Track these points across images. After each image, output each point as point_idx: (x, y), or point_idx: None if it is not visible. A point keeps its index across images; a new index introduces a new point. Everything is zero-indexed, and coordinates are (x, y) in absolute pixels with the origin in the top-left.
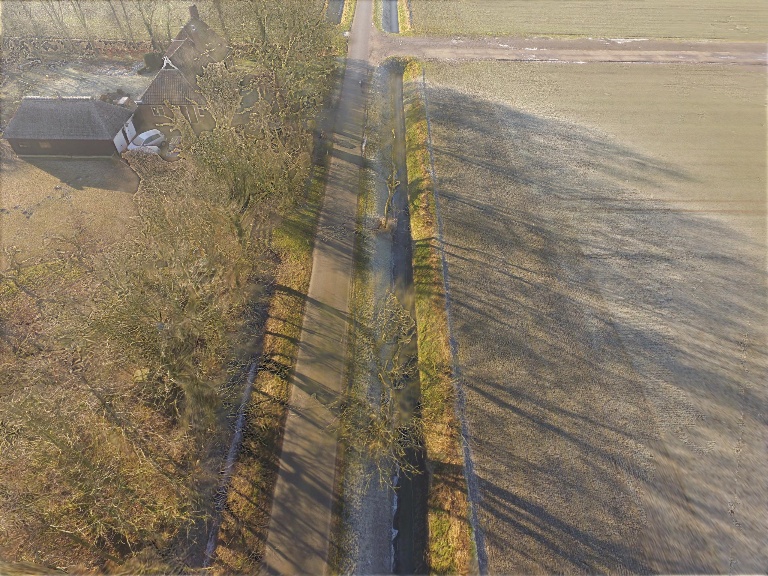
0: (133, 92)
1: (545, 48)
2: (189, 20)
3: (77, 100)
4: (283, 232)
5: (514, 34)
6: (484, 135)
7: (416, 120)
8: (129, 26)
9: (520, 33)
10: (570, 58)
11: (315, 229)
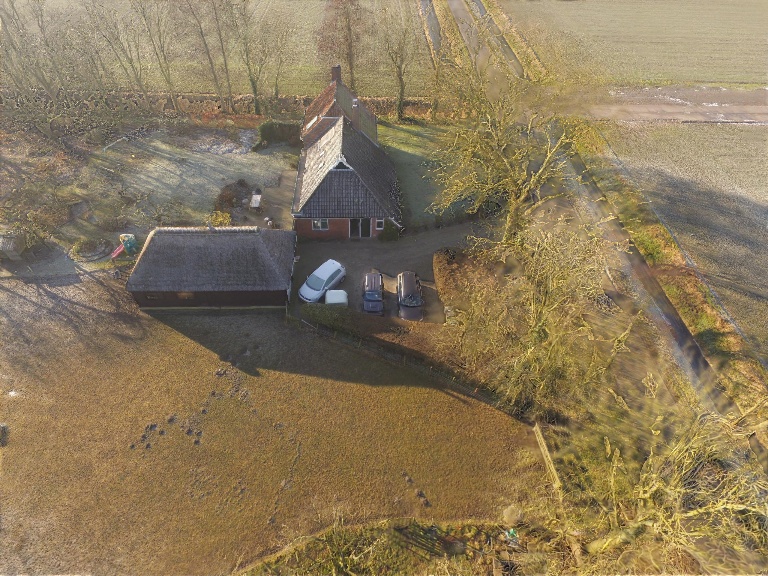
0: (258, 182)
1: (727, 103)
2: (336, 87)
3: (237, 233)
4: (598, 458)
5: (678, 83)
6: (754, 249)
7: (643, 221)
8: (229, 83)
9: (683, 81)
10: (767, 118)
11: (642, 450)
